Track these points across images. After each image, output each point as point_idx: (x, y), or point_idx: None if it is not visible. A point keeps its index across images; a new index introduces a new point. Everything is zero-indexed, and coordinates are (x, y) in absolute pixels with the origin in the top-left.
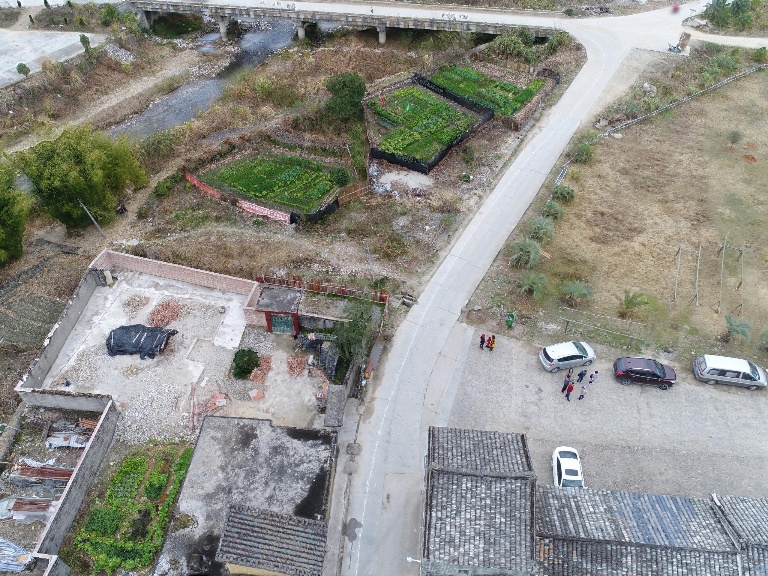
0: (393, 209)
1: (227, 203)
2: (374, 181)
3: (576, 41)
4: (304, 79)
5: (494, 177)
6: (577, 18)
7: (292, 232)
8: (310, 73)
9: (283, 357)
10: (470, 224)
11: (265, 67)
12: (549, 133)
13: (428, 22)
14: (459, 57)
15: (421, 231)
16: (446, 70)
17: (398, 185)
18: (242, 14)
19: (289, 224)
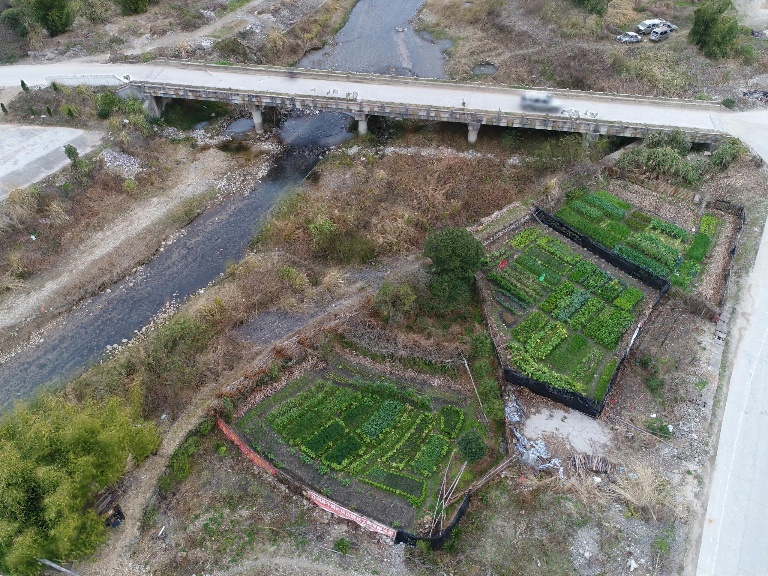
0: (564, 512)
1: (287, 490)
2: (518, 437)
3: (751, 151)
4: (375, 207)
5: (708, 430)
6: (739, 111)
7: (402, 568)
8: (382, 196)
9: None
10: (701, 552)
11: (316, 178)
12: (763, 327)
13: (541, 120)
14: (591, 176)
15: (623, 571)
16: (575, 197)
17: (556, 444)
18: (285, 104)
19: (394, 544)
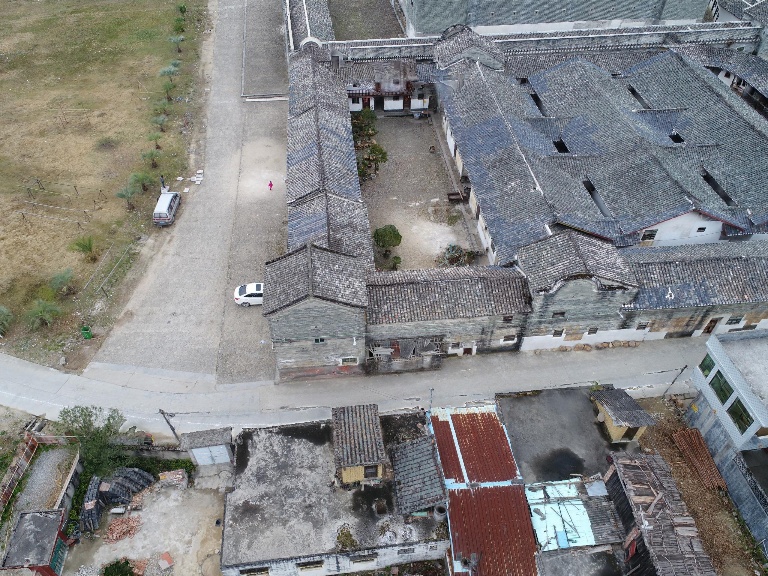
0: None
1: None
2: None
3: None
4: None
5: None
6: None
7: None
8: None
9: (106, 549)
10: None
11: None
12: None
13: None
14: None
15: None
16: None
17: None
18: None
19: None
